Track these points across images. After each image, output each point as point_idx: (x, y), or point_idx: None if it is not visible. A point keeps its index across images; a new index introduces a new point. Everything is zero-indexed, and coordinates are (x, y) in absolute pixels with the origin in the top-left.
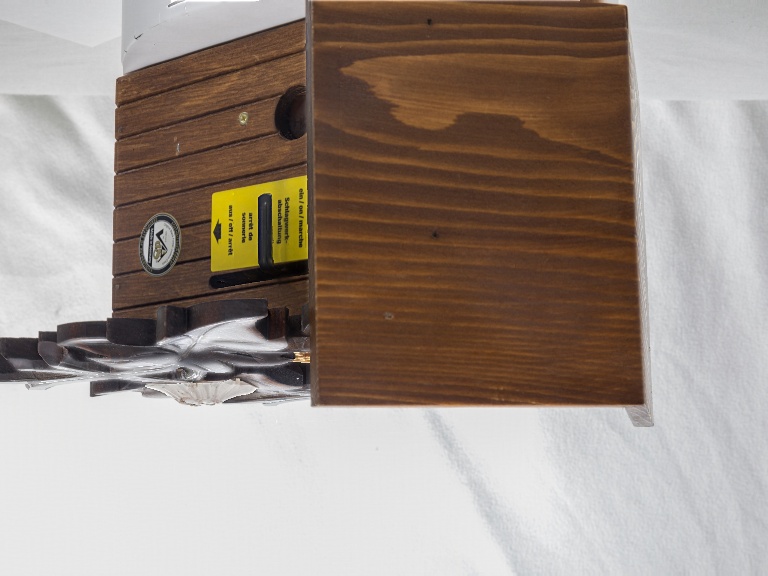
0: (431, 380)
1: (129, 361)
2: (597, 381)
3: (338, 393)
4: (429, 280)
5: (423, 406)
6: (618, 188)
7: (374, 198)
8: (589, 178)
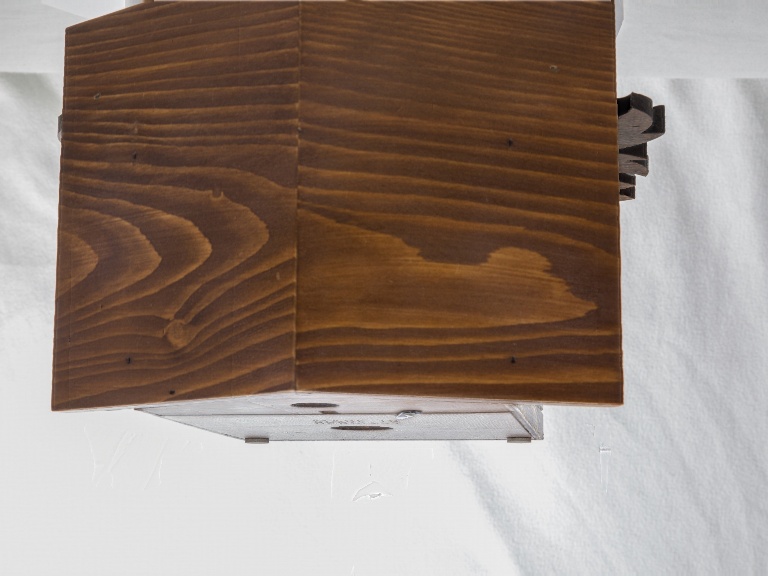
0: (517, 6)
1: None
2: None
3: (598, 5)
4: (517, 99)
5: None
6: (317, 182)
7: (567, 181)
8: (350, 194)
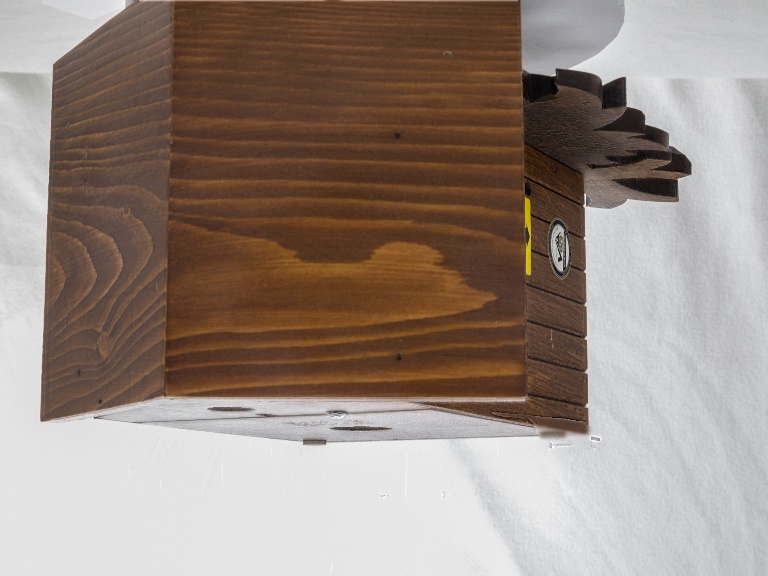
0: None
1: None
2: None
3: None
4: (406, 90)
5: None
6: (189, 192)
7: (462, 169)
8: (223, 201)
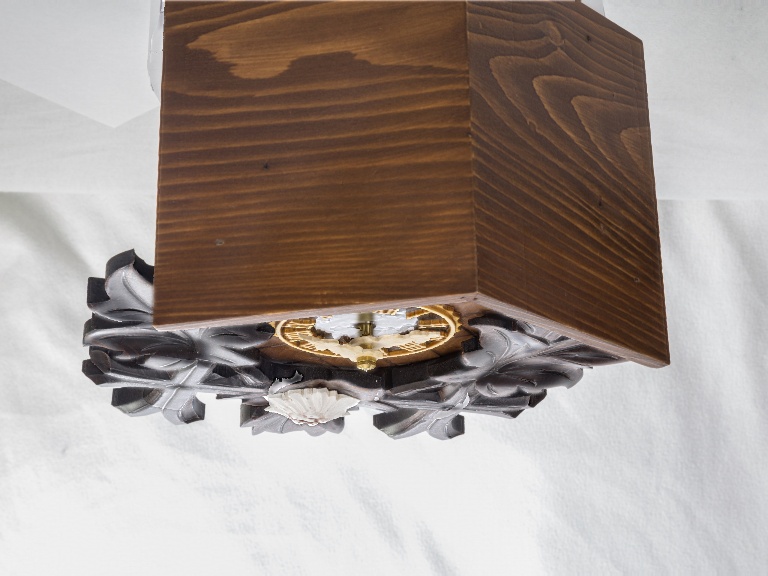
0: (256, 293)
1: (149, 356)
2: (424, 275)
3: (170, 314)
4: (259, 206)
5: (253, 318)
6: (451, 95)
7: (211, 145)
8: (421, 91)
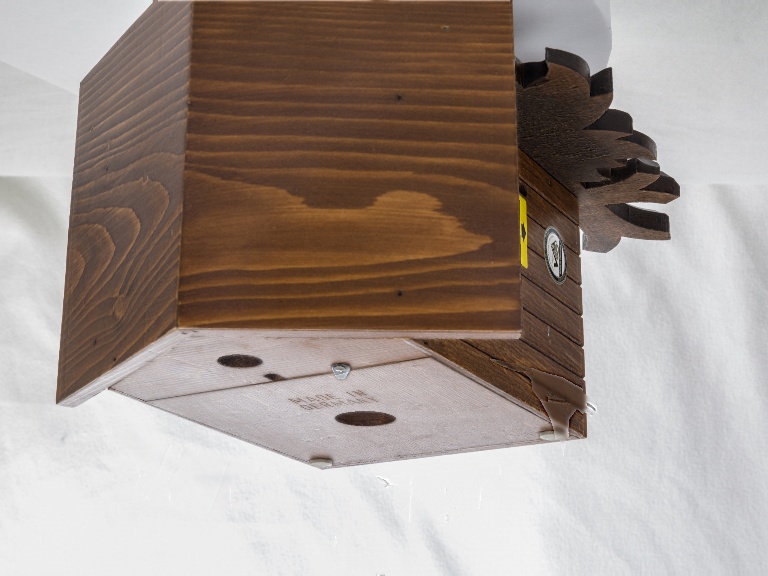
0: None
1: None
2: None
3: None
4: (406, 59)
5: None
6: (204, 146)
7: (459, 127)
8: (235, 154)
